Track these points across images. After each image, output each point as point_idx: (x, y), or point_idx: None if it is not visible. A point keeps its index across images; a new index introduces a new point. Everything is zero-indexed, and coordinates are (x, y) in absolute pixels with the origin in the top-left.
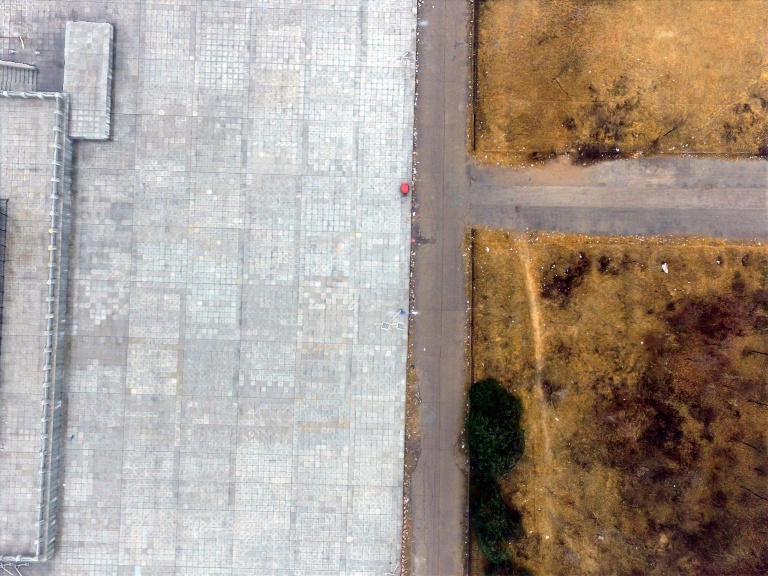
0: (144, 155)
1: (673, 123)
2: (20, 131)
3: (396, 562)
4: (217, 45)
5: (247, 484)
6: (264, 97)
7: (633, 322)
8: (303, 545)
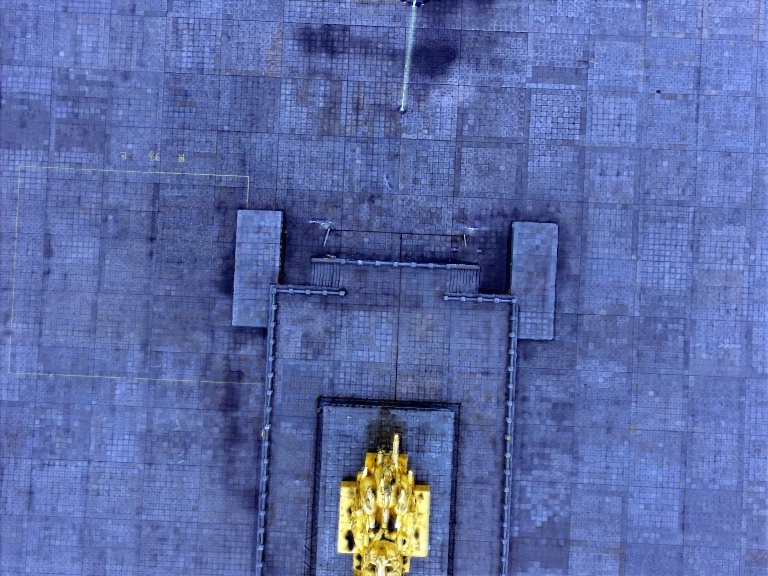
0: (585, 355)
1: None
2: (472, 334)
3: None
4: (660, 244)
5: None
6: (707, 298)
7: None
8: None
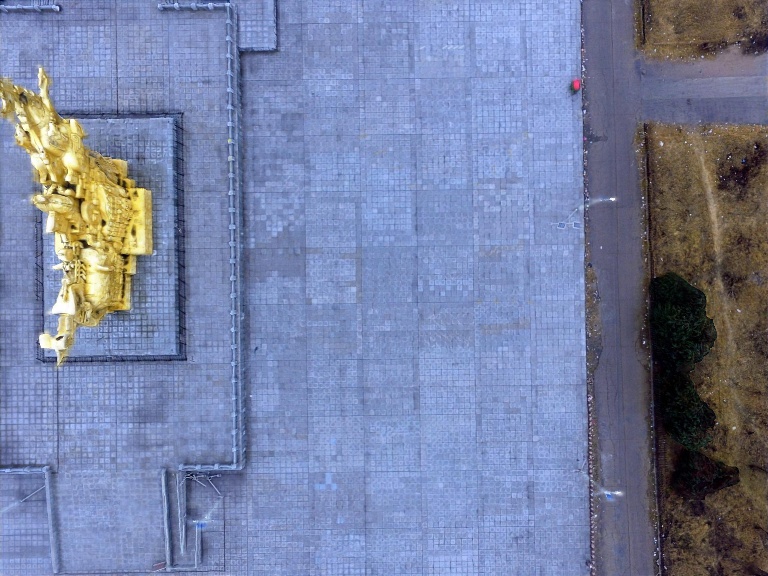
0: (312, 65)
1: None
2: (191, 44)
3: (583, 459)
4: None
5: (431, 388)
6: None
7: None
8: (490, 446)
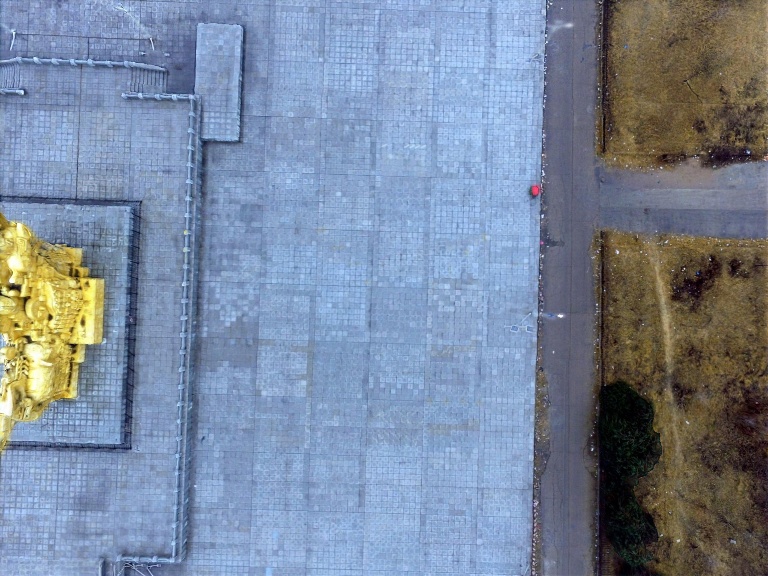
0: (273, 157)
1: None
2: (153, 133)
3: (526, 565)
4: (346, 47)
5: (377, 486)
6: (393, 99)
7: (765, 325)
8: (433, 547)
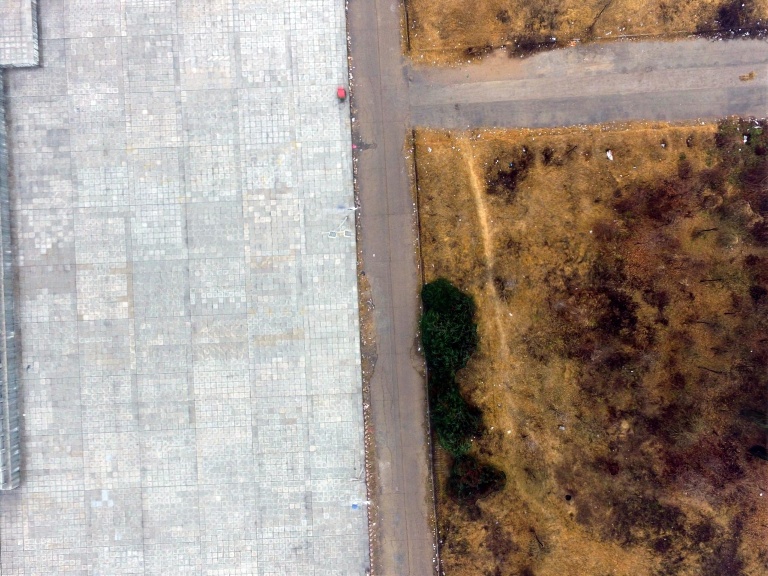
0: (76, 79)
1: (608, 7)
2: None
3: (360, 467)
4: None
5: (206, 401)
6: (192, 11)
7: (580, 211)
8: (267, 457)
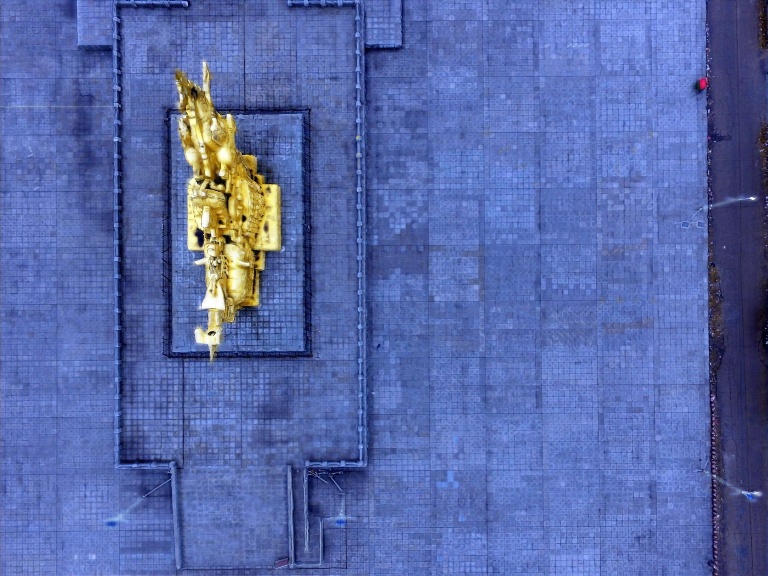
0: (436, 62)
1: None
2: (319, 40)
3: (706, 459)
4: None
5: (554, 387)
6: None
7: None
8: (612, 445)
